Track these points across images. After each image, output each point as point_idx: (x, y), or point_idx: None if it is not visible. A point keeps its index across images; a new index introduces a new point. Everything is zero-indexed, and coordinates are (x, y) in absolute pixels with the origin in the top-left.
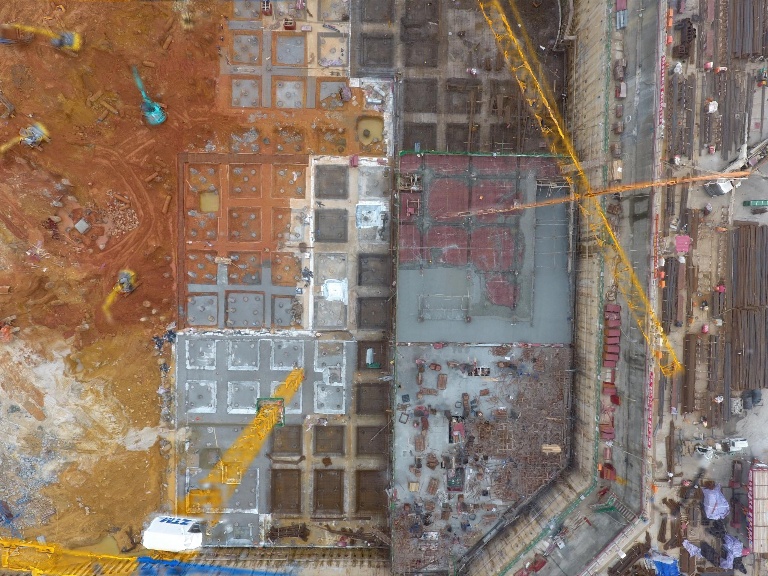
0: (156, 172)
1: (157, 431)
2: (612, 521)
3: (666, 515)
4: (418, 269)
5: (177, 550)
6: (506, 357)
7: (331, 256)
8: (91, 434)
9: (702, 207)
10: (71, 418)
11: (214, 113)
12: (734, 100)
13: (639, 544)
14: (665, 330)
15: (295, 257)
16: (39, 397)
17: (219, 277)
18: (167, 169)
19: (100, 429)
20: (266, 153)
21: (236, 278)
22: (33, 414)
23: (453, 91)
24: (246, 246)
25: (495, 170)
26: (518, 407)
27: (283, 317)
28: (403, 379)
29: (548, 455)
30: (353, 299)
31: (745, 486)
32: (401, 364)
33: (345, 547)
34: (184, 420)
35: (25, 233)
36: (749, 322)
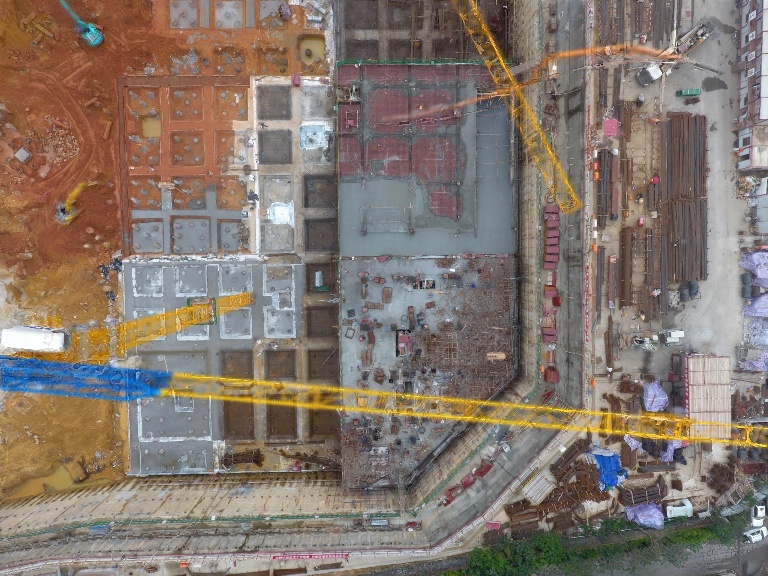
0: (95, 97)
1: None
2: (554, 420)
3: (606, 410)
4: (359, 182)
5: (37, 348)
6: (451, 269)
7: (276, 179)
8: None
9: (635, 99)
10: None
11: (152, 35)
12: None
13: (580, 440)
14: (600, 224)
15: (240, 181)
16: None
17: (163, 202)
18: (106, 94)
19: (45, 356)
20: (206, 75)
21: (181, 203)
22: None
23: (394, 6)
24: (189, 170)
25: (434, 79)
26: (464, 319)
27: (230, 242)
28: (348, 294)
29: (495, 366)
30: (300, 221)
31: (684, 378)
32: (345, 279)
33: (300, 471)
34: (133, 348)
35: None
36: (684, 213)
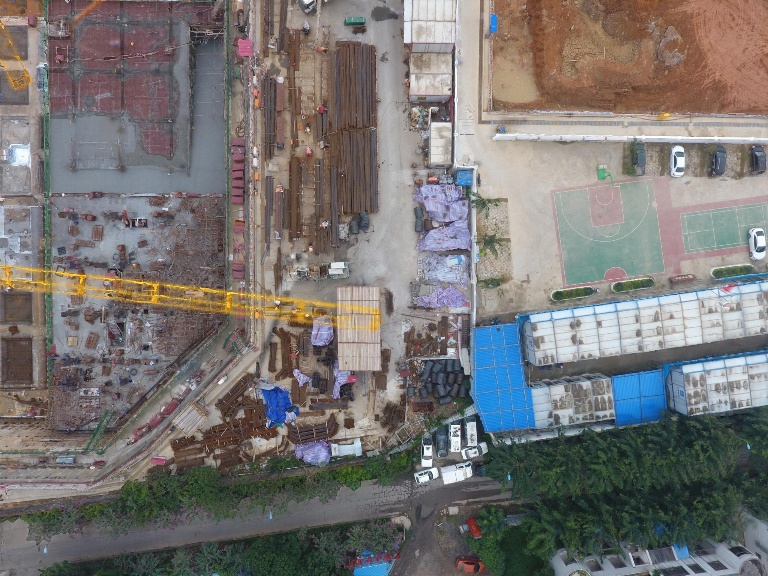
0: None
1: None
2: (231, 356)
3: (274, 344)
4: None
5: None
6: (164, 208)
7: (15, 120)
8: None
9: (302, 27)
10: None
11: None
12: None
13: (247, 374)
14: (266, 152)
15: None
16: None
17: None
18: None
19: None
20: None
21: None
22: None
23: None
24: None
25: (147, 16)
26: None
27: None
28: (58, 231)
29: (207, 307)
30: (35, 162)
31: None
32: (56, 216)
33: (34, 417)
34: None
35: None
36: (352, 144)
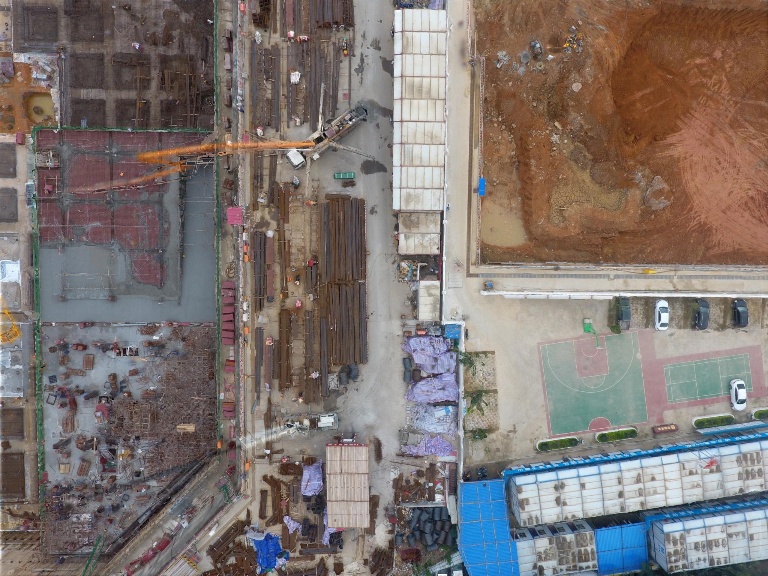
0: None
1: None
2: (222, 499)
3: (264, 492)
4: (60, 248)
5: None
6: (155, 336)
7: (4, 236)
8: None
9: (292, 180)
10: None
11: None
12: (319, 70)
13: (238, 521)
14: (256, 305)
15: None
16: None
17: None
18: None
19: None
20: None
21: None
22: None
23: (119, 66)
24: None
25: (136, 146)
26: None
27: None
28: (49, 360)
29: None
30: (25, 280)
31: None
32: (46, 344)
33: (27, 531)
34: None
35: None
36: (341, 297)
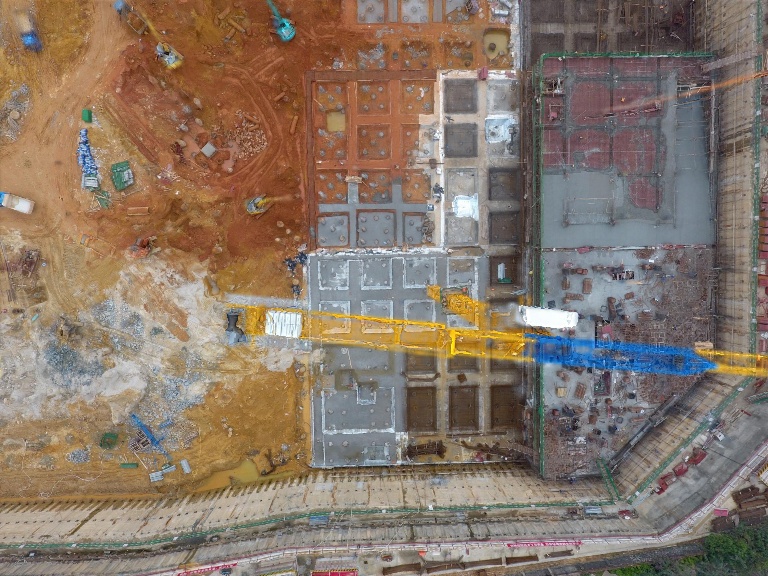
0: (283, 92)
1: (292, 353)
2: None
3: None
4: (561, 174)
5: None
6: (650, 260)
7: (460, 172)
8: (234, 354)
9: None
10: (214, 338)
11: (341, 29)
12: None
13: None
14: None
15: (424, 174)
16: (182, 317)
17: (350, 196)
18: (294, 88)
19: (243, 349)
20: (394, 69)
21: (366, 197)
22: (177, 335)
23: None
24: (376, 164)
25: (636, 72)
26: (663, 309)
27: (414, 235)
28: (549, 285)
29: (694, 356)
30: (484, 214)
31: None
32: (546, 270)
33: (482, 462)
34: (318, 341)
35: (156, 156)
36: None
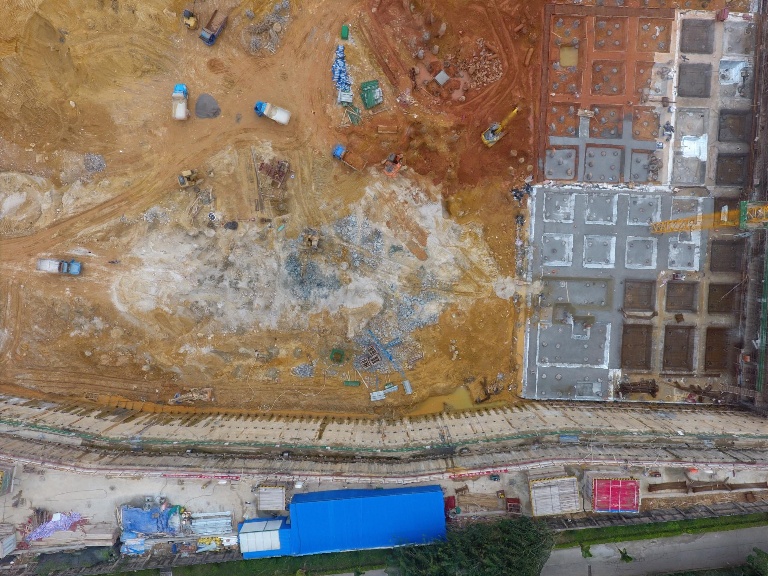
0: (522, 23)
1: (513, 283)
2: None
3: None
4: None
5: None
6: None
7: (690, 112)
8: (468, 276)
9: None
10: (451, 259)
11: None
12: None
13: None
14: None
15: (654, 113)
16: (423, 236)
17: (581, 130)
18: None
19: (477, 272)
20: (633, 6)
21: (595, 132)
22: (415, 254)
23: None
24: (609, 99)
25: None
26: None
27: (639, 173)
28: None
29: None
30: (714, 154)
31: None
32: None
33: (695, 403)
34: (539, 273)
35: (397, 79)
36: None
